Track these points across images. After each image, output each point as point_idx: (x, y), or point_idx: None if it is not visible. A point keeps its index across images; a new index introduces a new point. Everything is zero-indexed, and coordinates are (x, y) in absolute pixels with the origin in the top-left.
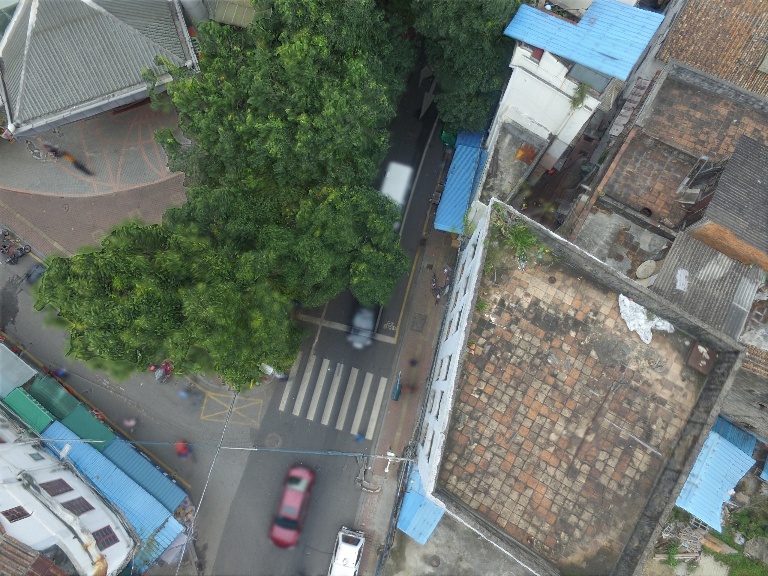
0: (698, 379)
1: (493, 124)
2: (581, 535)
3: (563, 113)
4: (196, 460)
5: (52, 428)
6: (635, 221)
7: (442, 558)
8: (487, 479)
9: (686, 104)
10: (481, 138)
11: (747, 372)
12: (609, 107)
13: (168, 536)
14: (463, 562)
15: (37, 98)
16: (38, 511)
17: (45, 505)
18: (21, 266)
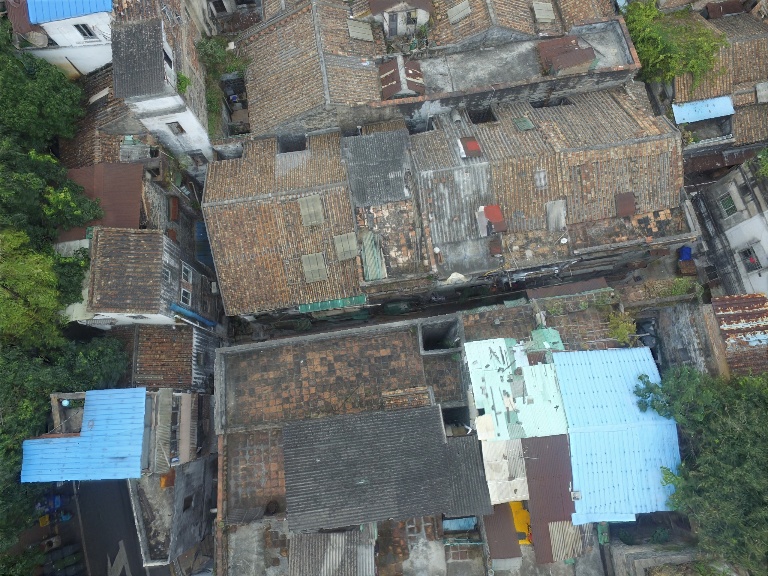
0: None
1: None
2: None
3: None
4: None
5: None
6: None
7: None
8: None
9: (257, 371)
10: None
11: None
12: (167, 466)
13: None
14: None
15: None
16: None
17: None
18: None
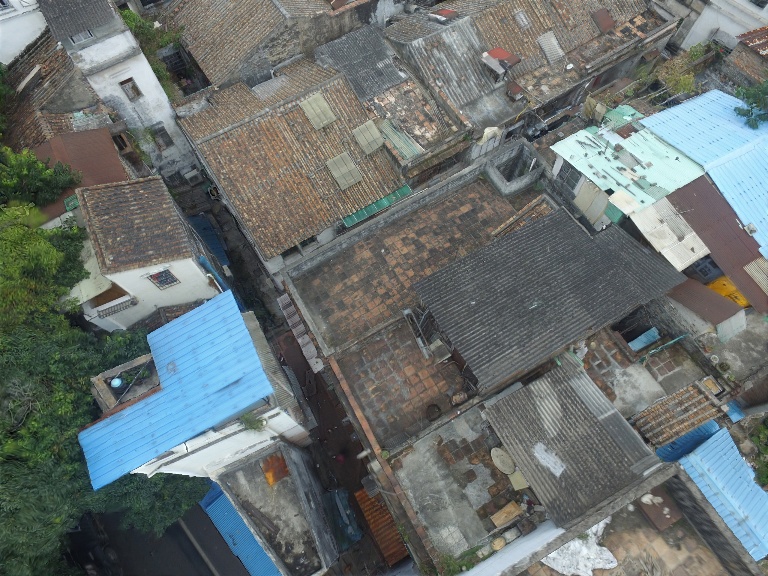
0: (682, 527)
1: None
2: None
3: None
4: None
5: None
6: None
7: None
8: None
9: (336, 281)
10: None
11: None
12: (290, 397)
13: None
14: None
15: None
16: None
17: None
18: None
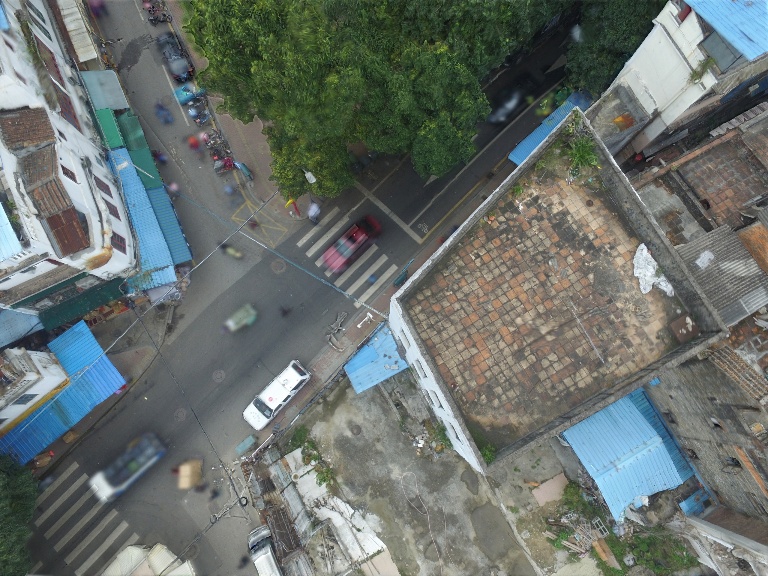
0: (671, 344)
1: (609, 87)
2: (498, 406)
3: (678, 87)
4: (211, 247)
5: (119, 152)
6: (691, 208)
7: (363, 431)
8: (445, 323)
9: None
10: None
11: (719, 370)
12: (723, 91)
13: (162, 279)
14: (379, 444)
15: None
16: (84, 186)
17: (90, 187)
18: (157, 30)
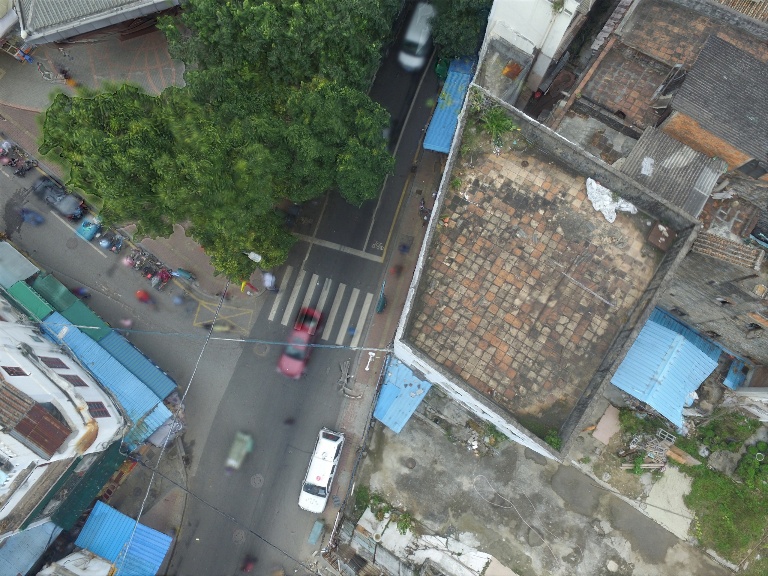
0: (657, 256)
1: None
2: (539, 389)
3: (546, 22)
4: (187, 363)
5: (52, 318)
6: (610, 124)
7: (418, 461)
8: (453, 337)
9: (665, 20)
10: (472, 64)
11: (706, 257)
12: (587, 9)
13: (157, 420)
14: (438, 465)
15: (49, 7)
16: (35, 374)
17: (42, 371)
18: (28, 179)
